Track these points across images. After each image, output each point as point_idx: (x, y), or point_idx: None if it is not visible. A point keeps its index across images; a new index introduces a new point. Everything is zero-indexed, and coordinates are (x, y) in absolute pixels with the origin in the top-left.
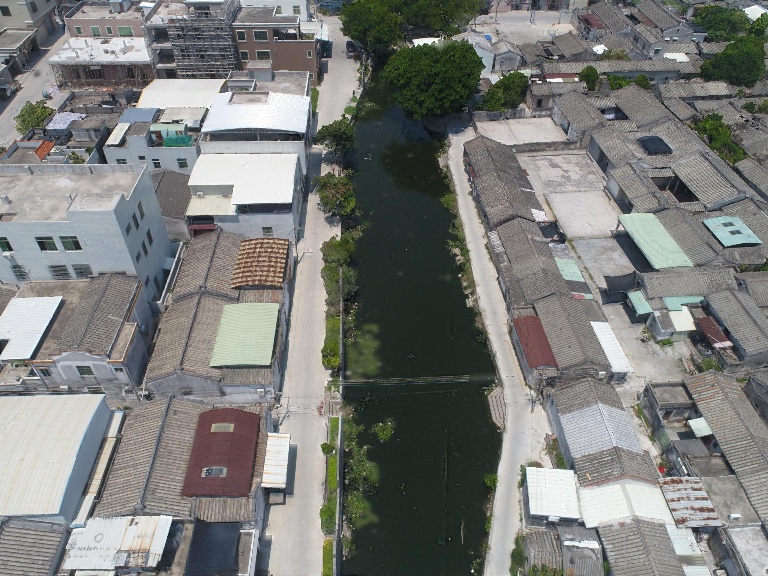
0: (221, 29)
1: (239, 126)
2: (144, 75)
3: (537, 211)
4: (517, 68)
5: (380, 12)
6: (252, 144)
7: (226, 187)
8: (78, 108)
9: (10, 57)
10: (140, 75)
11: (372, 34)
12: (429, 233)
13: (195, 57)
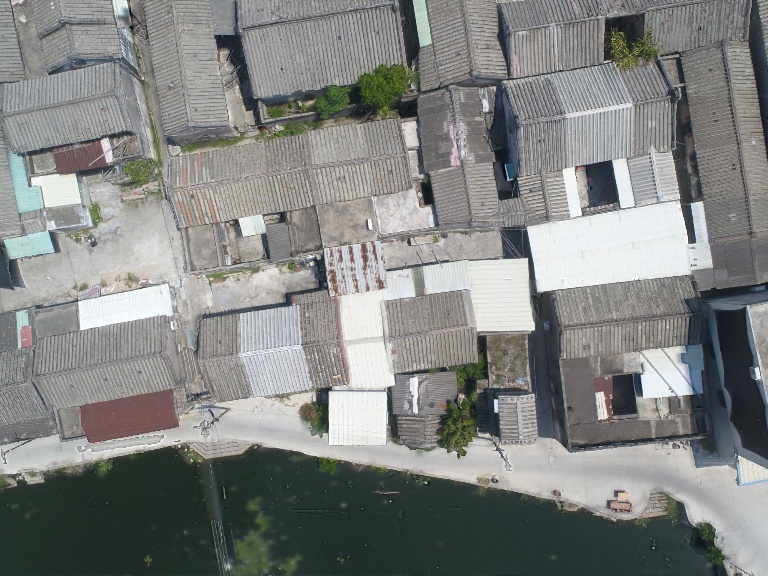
0: None
1: None
2: None
3: None
4: None
5: None
6: None
7: None
8: None
9: None
10: None
11: None
12: None
13: None
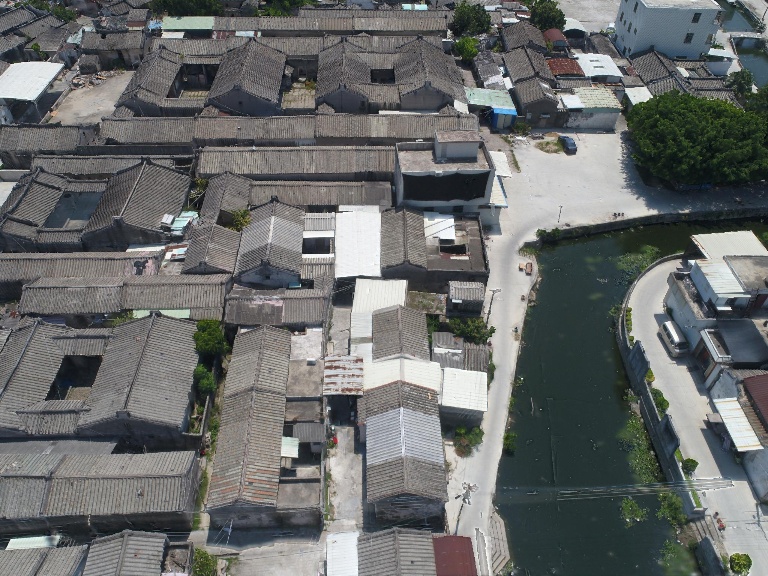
0: None
1: None
2: None
3: None
4: None
5: None
6: None
7: None
8: None
9: None
10: None
11: None
12: None
13: None
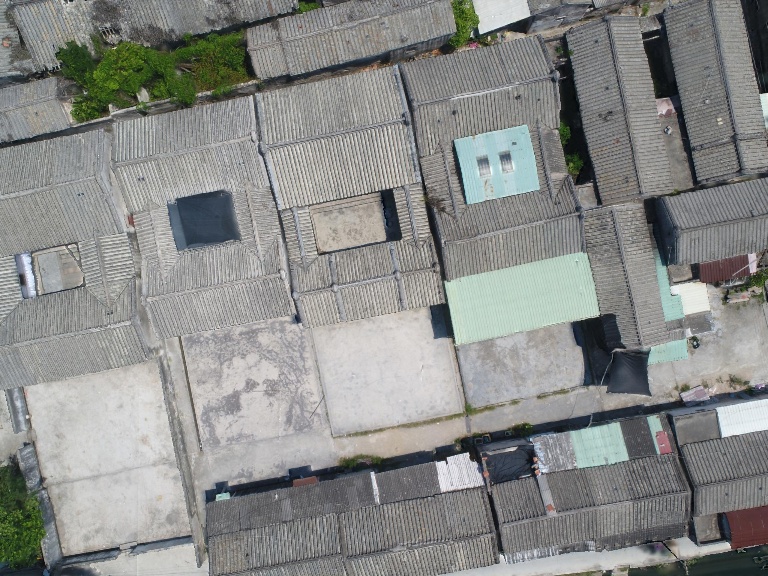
0: None
1: None
2: None
3: (442, 478)
4: None
5: None
6: None
7: None
8: None
9: None
10: None
11: None
12: None
13: None
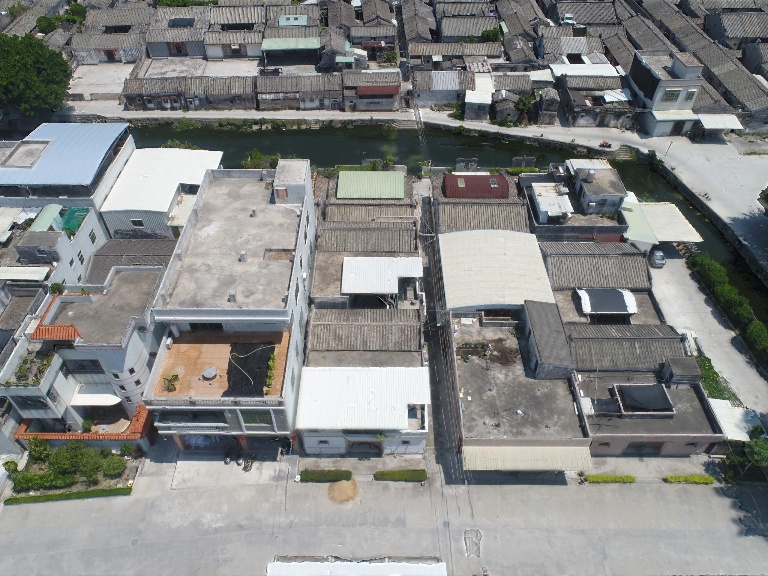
0: None
1: (101, 155)
2: None
3: None
4: None
5: None
6: (114, 166)
7: None
8: None
9: None
10: None
11: None
12: None
13: None
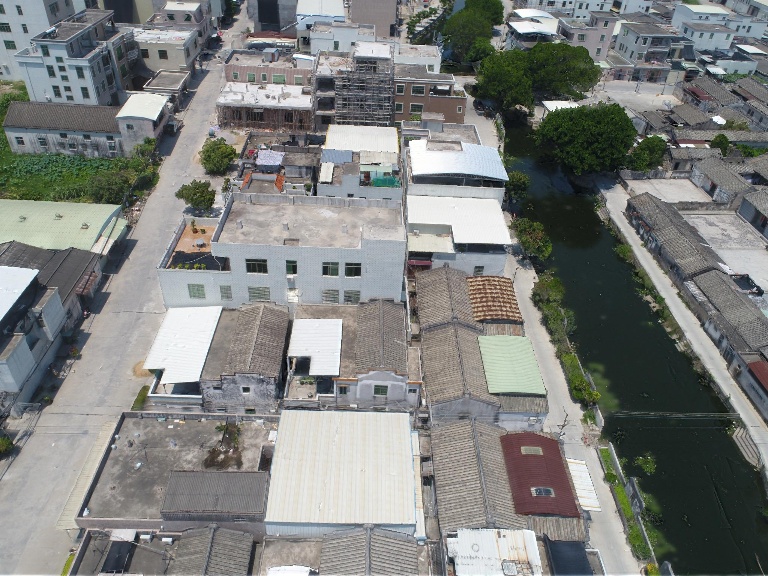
0: (385, 82)
1: (449, 171)
2: (301, 120)
3: (722, 265)
4: (646, 133)
5: (519, 75)
6: (457, 188)
7: (442, 227)
8: (277, 147)
9: (172, 96)
10: (298, 120)
11: (510, 94)
12: (614, 280)
13: (355, 106)
